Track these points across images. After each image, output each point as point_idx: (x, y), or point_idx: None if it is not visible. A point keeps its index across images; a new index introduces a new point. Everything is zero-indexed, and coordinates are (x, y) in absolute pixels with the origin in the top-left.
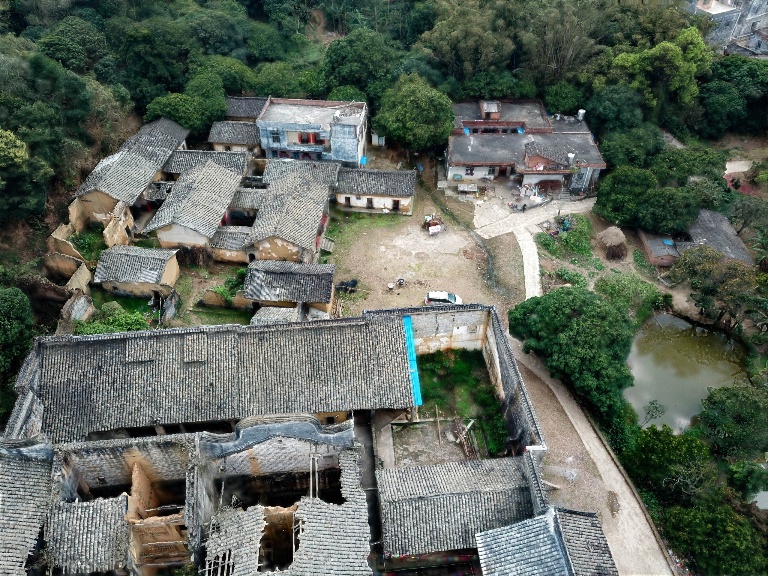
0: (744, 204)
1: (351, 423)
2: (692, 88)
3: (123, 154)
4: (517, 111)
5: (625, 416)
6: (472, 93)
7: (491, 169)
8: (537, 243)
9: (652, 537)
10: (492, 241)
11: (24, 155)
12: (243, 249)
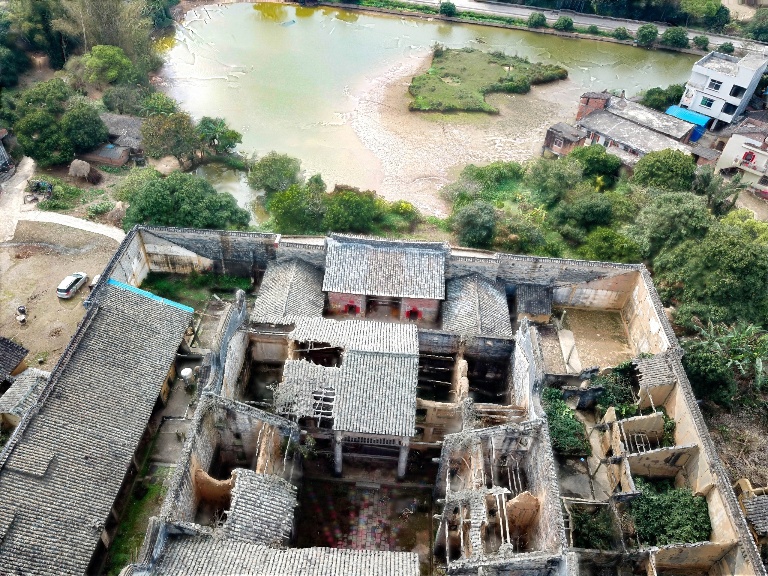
0: (111, 96)
1: (242, 291)
2: None
3: None
4: None
5: None
6: None
7: None
8: (48, 211)
9: None
10: (19, 236)
11: None
12: None
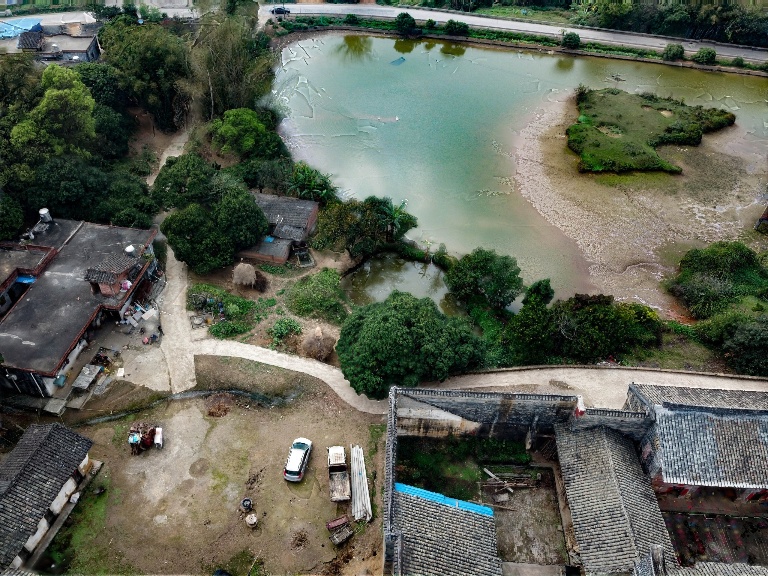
0: (256, 173)
1: None
2: (93, 120)
3: None
4: None
5: None
6: None
7: None
8: (225, 338)
9: (588, 370)
10: (203, 380)
11: None
12: None
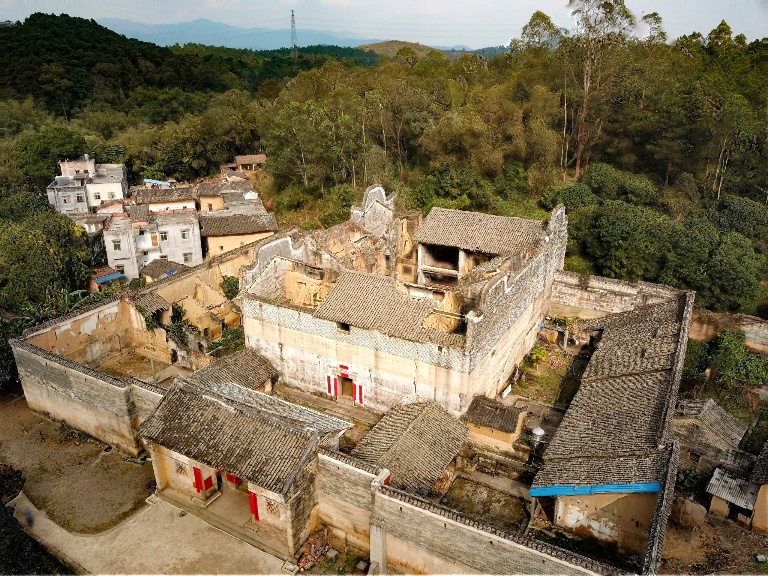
0: None
1: None
2: None
3: None
4: None
5: None
6: None
7: None
8: None
9: None
10: None
11: None
12: None
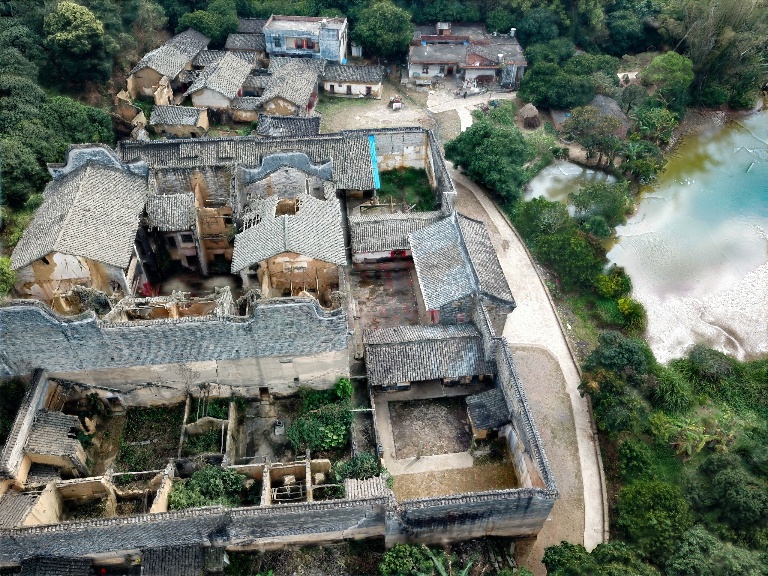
0: (627, 89)
1: (330, 158)
2: (597, 11)
3: (164, 47)
4: (465, 31)
5: (520, 202)
6: (430, 18)
7: (442, 68)
8: (473, 116)
9: (528, 259)
10: (439, 114)
11: (102, 29)
12: (255, 109)
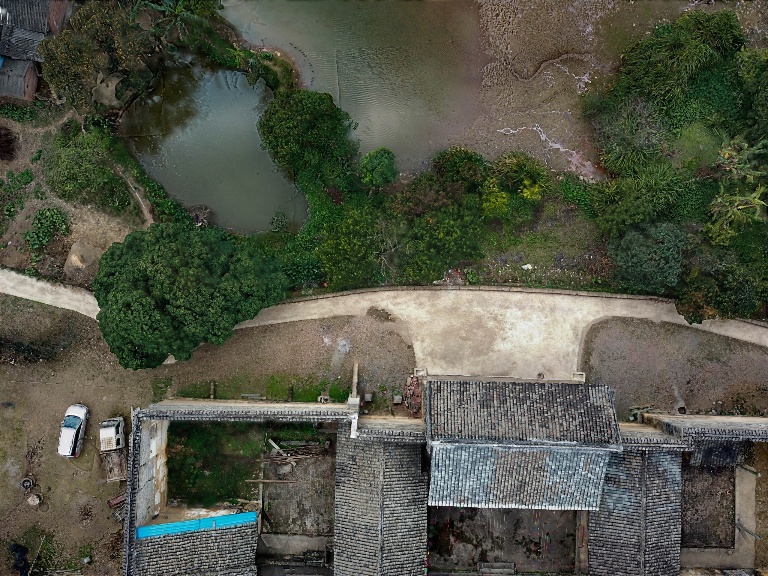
0: None
1: None
2: None
3: None
4: None
5: None
6: None
7: None
8: None
9: (419, 293)
10: None
11: None
12: None
